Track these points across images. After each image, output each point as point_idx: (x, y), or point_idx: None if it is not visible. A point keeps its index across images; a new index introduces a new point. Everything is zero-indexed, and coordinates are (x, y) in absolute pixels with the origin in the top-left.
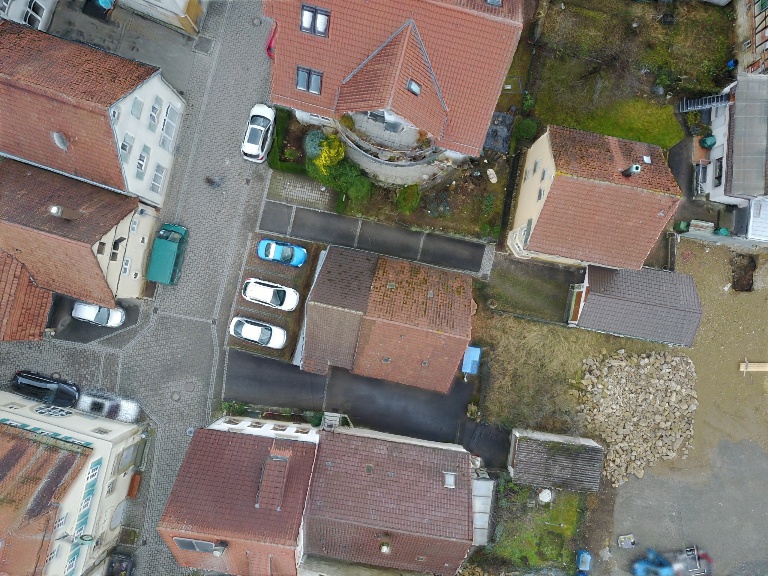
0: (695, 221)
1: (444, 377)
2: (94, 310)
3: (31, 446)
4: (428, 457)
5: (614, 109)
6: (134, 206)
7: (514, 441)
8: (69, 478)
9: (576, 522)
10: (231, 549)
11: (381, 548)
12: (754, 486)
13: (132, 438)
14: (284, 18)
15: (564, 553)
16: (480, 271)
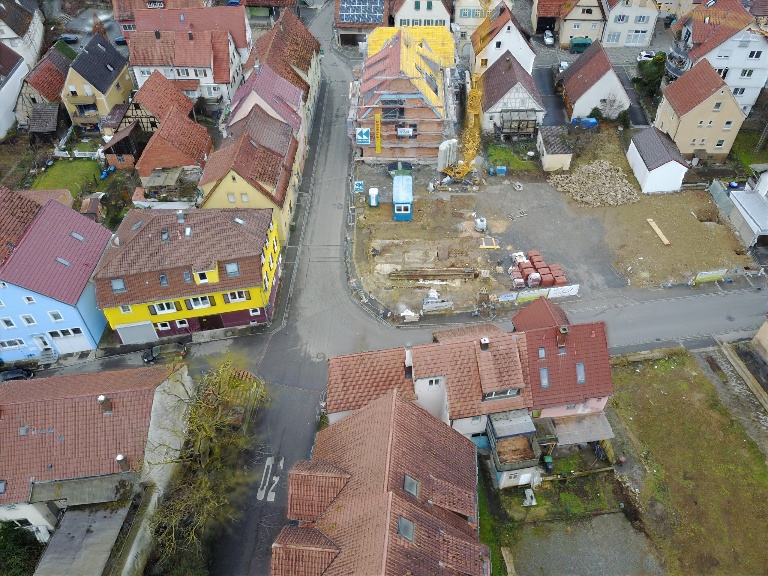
0: (722, 182)
1: None
2: (550, 34)
3: None
4: None
5: (758, 160)
6: (604, 17)
7: None
8: None
9: None
10: None
11: None
12: (578, 235)
13: None
14: (705, 1)
15: None
16: (634, 125)
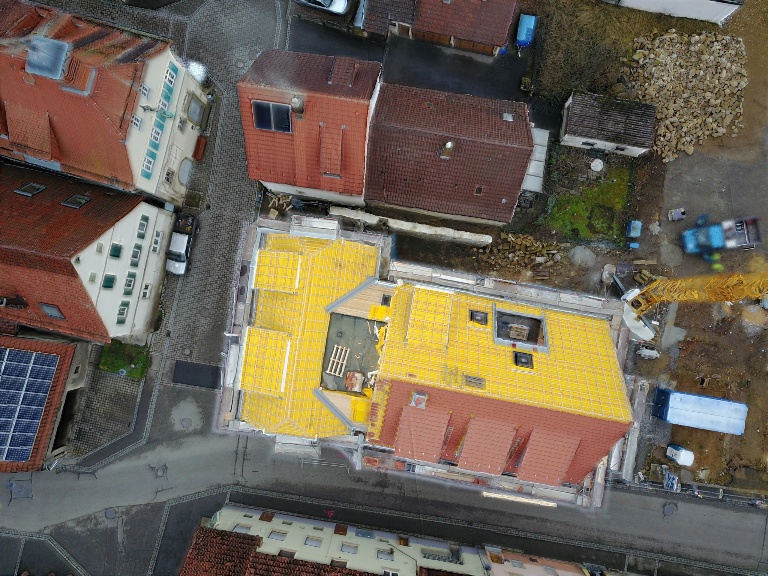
0: None
1: (503, 19)
2: None
3: (115, 32)
4: (486, 104)
5: None
6: None
7: (566, 115)
8: (152, 51)
9: (627, 196)
10: (305, 121)
11: (446, 144)
12: None
13: (200, 92)
14: None
15: (615, 226)
16: None
